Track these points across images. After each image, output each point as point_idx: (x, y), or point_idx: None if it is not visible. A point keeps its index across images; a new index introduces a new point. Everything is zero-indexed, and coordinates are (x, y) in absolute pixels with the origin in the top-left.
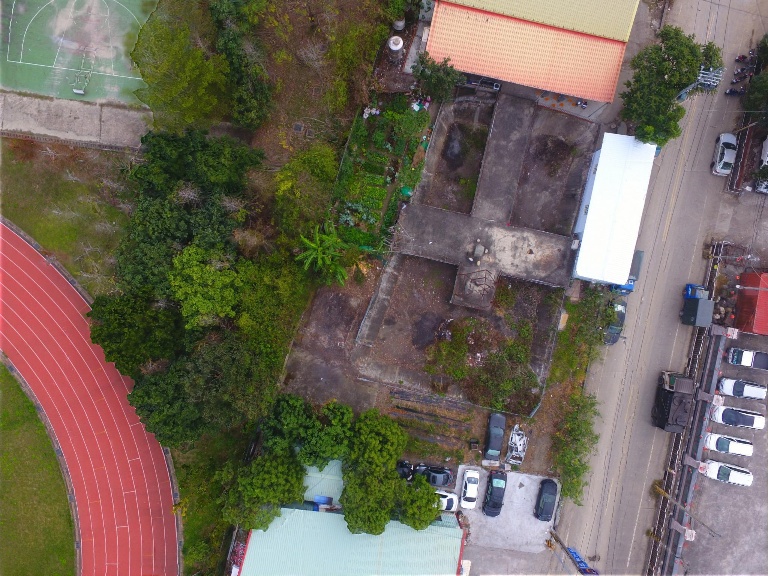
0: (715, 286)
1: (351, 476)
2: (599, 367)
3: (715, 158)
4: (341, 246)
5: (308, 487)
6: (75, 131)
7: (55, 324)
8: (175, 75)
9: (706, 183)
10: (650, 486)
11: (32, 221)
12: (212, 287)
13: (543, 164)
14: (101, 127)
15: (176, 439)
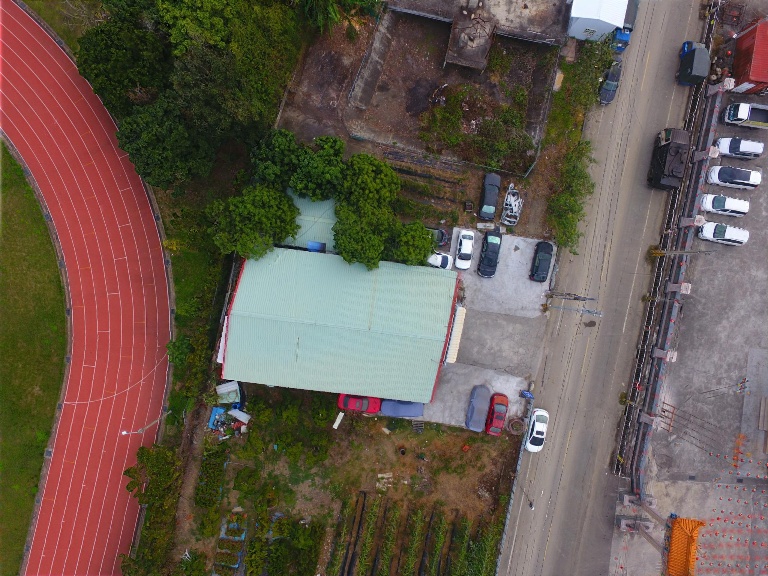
0: (712, 46)
1: (344, 205)
2: (595, 130)
3: None
4: None
5: (301, 229)
6: None
7: (42, 85)
8: None
9: None
10: (646, 252)
11: None
12: (201, 11)
13: None
14: None
15: (166, 170)
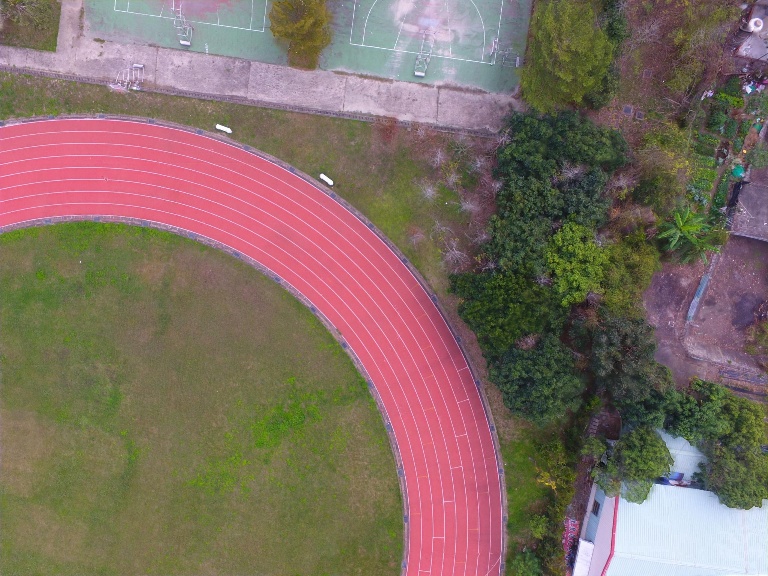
0: None
1: (725, 451)
2: None
3: None
4: (700, 225)
5: None
6: (413, 113)
7: (387, 302)
8: (584, 54)
9: None
10: None
11: (367, 201)
12: (590, 264)
13: None
14: (438, 109)
15: (549, 413)
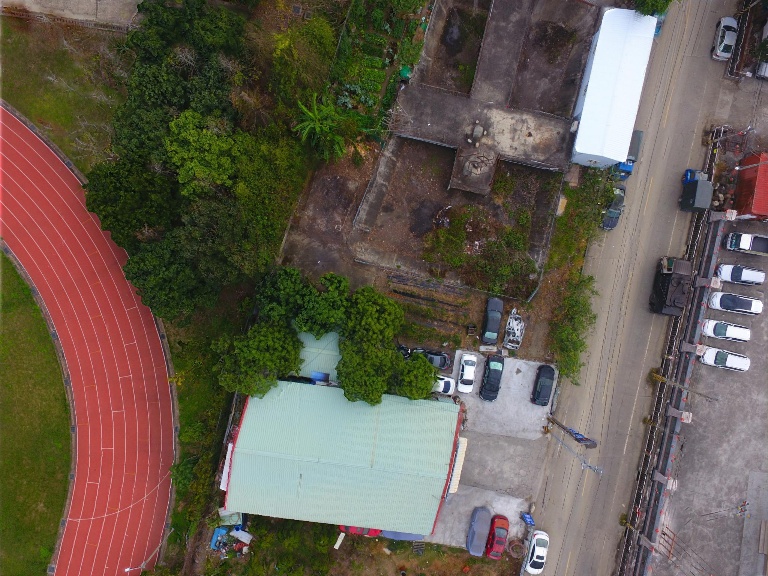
0: (714, 172)
1: (348, 344)
2: (597, 254)
3: (715, 42)
4: (339, 119)
5: (305, 361)
6: (71, 9)
7: (51, 206)
8: None
9: (706, 69)
10: (647, 374)
11: (27, 101)
12: (209, 153)
13: (543, 51)
14: (97, 6)
15: (172, 307)
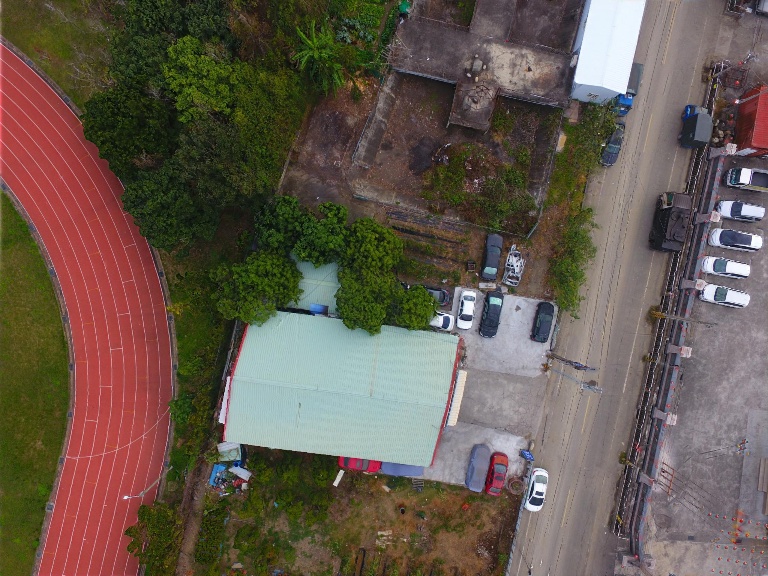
0: (714, 109)
1: (347, 272)
2: (597, 191)
3: None
4: (338, 48)
5: (303, 293)
6: None
7: (48, 142)
8: None
9: (706, 5)
10: (647, 312)
11: (25, 36)
12: (207, 79)
13: None
14: None
15: (170, 235)
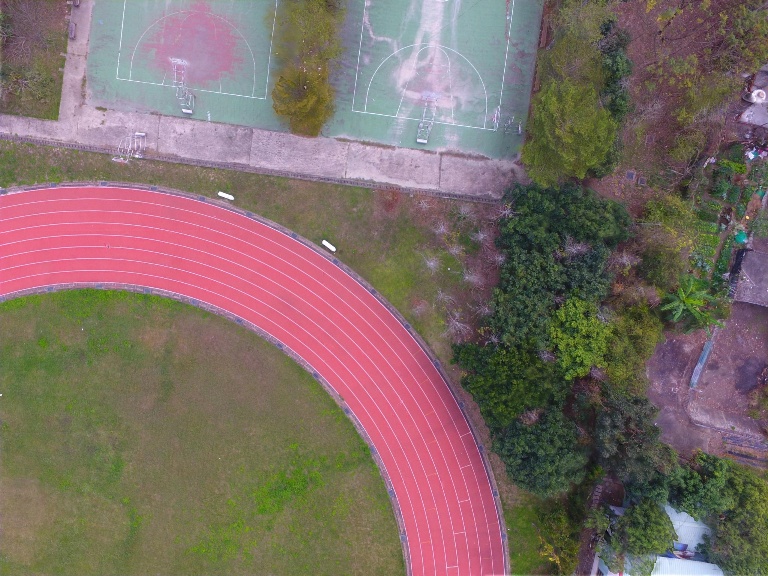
0: None
1: (729, 526)
2: None
3: None
4: (703, 297)
5: None
6: (415, 179)
7: (390, 368)
8: (587, 135)
9: None
10: None
11: (370, 267)
12: (593, 339)
13: None
14: (440, 175)
15: (553, 488)
